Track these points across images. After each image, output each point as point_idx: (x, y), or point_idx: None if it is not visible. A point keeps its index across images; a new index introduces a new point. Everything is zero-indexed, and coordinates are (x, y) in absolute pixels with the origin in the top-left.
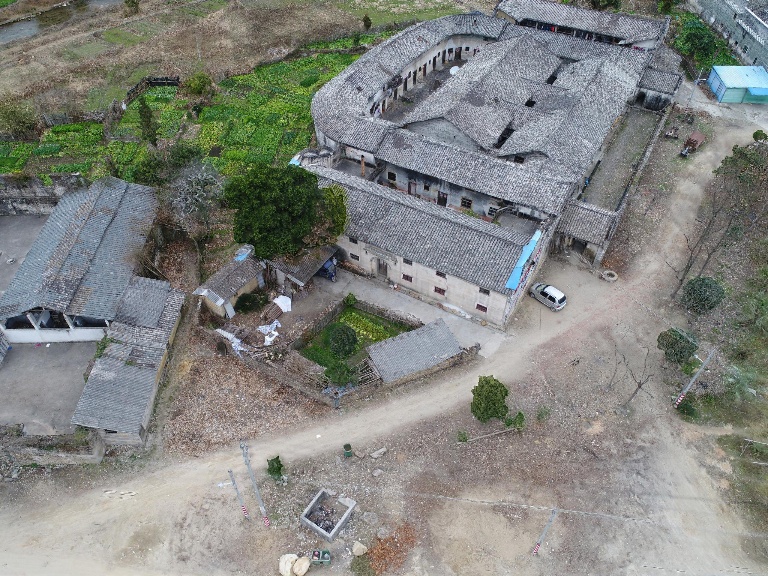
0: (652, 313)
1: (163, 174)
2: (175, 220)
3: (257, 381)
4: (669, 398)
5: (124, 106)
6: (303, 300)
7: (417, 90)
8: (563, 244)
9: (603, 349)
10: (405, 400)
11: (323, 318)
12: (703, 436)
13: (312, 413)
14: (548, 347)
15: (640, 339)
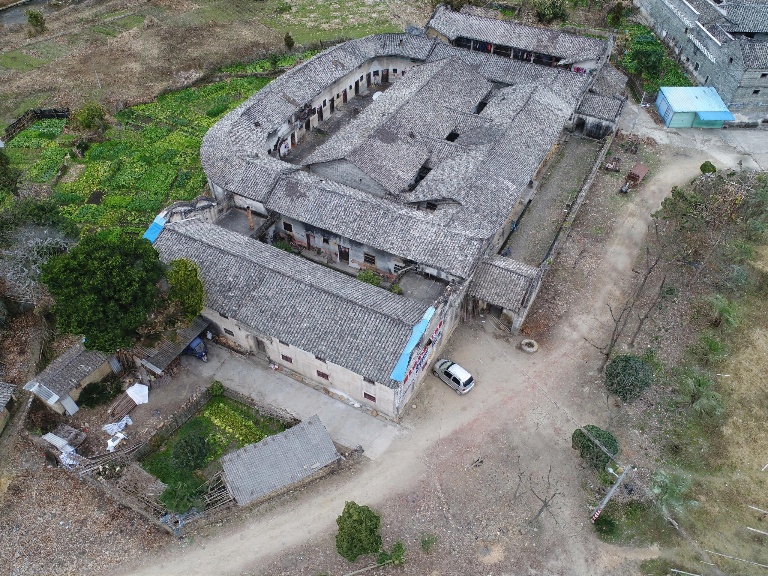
0: (574, 393)
1: (13, 233)
2: (20, 291)
3: (89, 501)
4: (586, 509)
5: (2, 144)
6: (164, 387)
7: (335, 119)
8: (477, 307)
9: (513, 444)
10: (266, 523)
11: (180, 414)
12: (623, 562)
13: (149, 546)
14: (448, 443)
15: (558, 428)
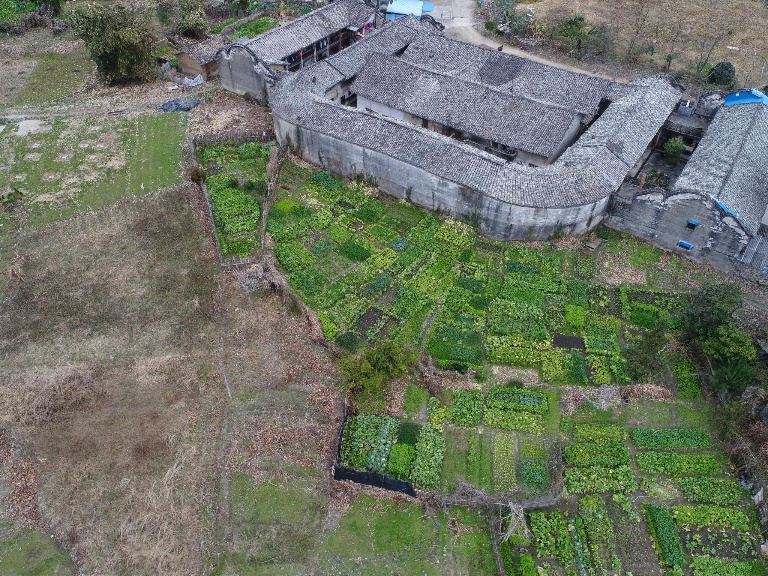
0: None
1: None
2: None
3: None
4: None
5: None
6: None
7: None
8: None
9: None
10: None
11: None
12: None
13: None
14: None
15: None
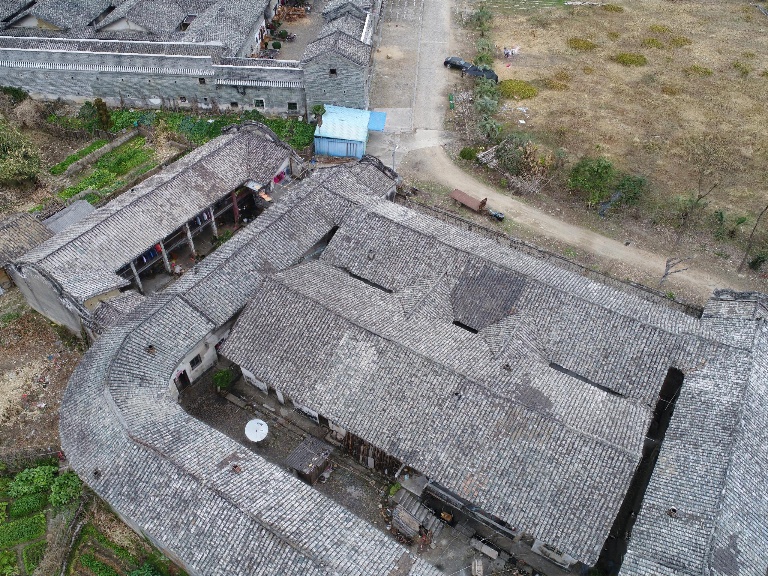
0: None
1: None
2: None
3: None
4: None
5: None
6: None
7: None
8: None
9: None
10: None
11: None
12: None
13: None
14: None
15: None
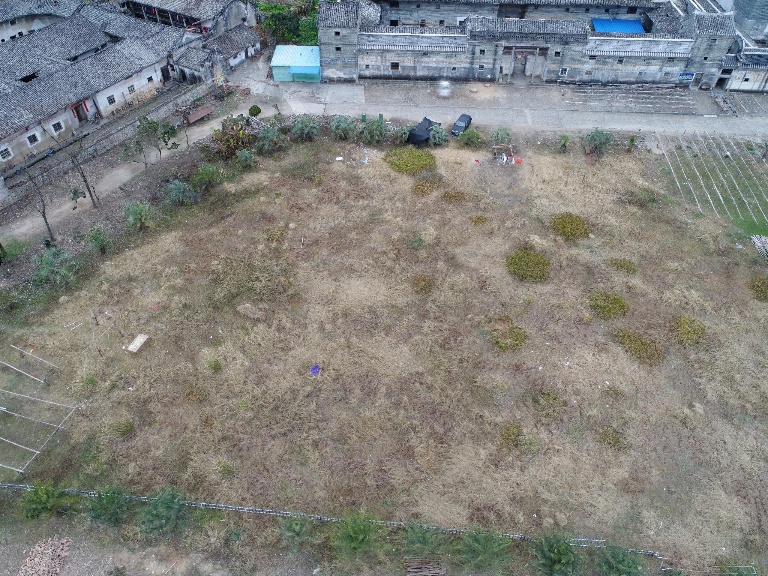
0: None
1: None
2: None
3: None
4: None
5: None
6: None
7: None
8: None
9: None
10: None
11: None
12: None
13: None
14: None
15: None
